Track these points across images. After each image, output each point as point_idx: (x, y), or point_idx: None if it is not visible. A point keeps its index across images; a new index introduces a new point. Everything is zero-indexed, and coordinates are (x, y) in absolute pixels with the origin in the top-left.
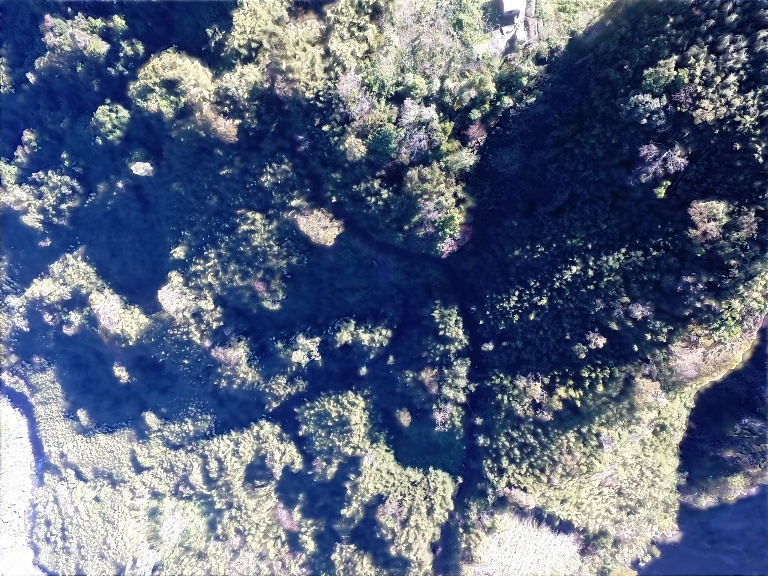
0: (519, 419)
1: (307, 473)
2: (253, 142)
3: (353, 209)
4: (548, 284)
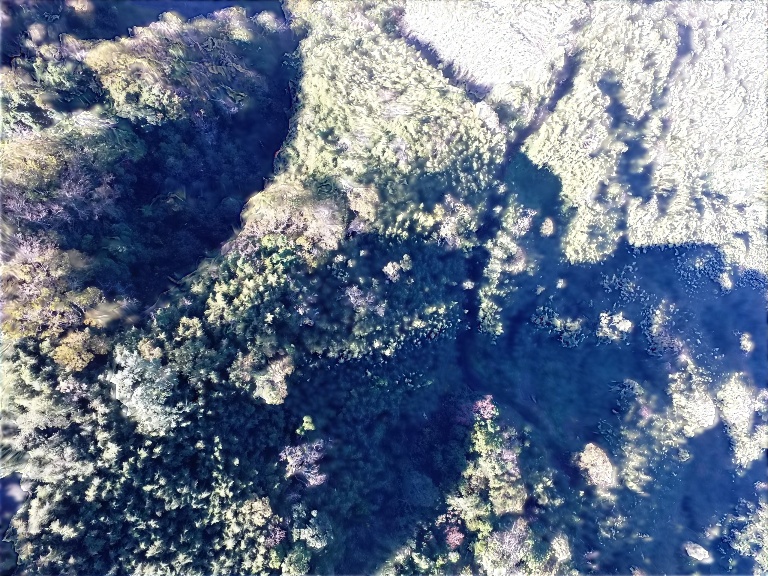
0: None
1: None
2: (614, 560)
3: (562, 475)
4: None
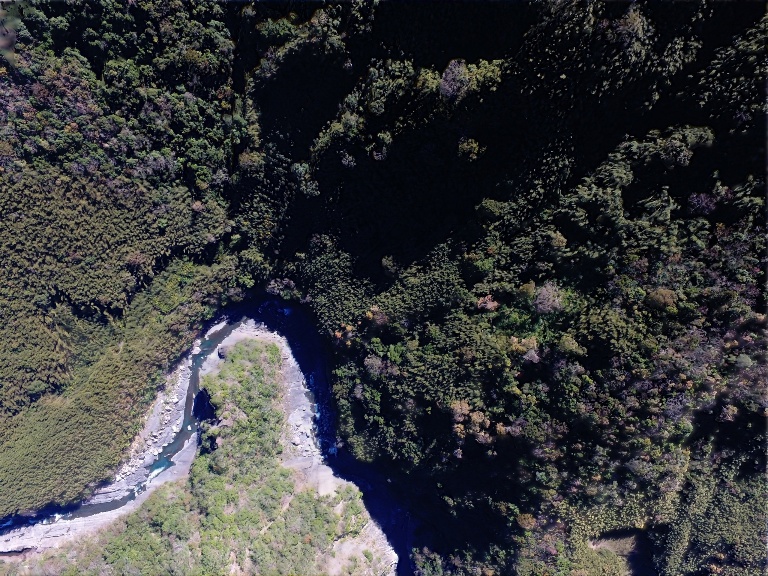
0: None
1: (719, 144)
2: None
3: None
4: None
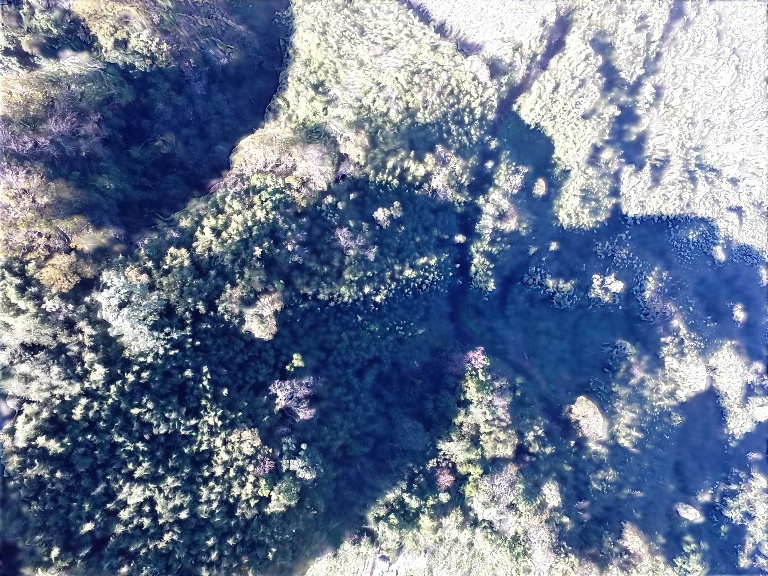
0: None
1: None
2: (606, 514)
3: (554, 426)
4: None
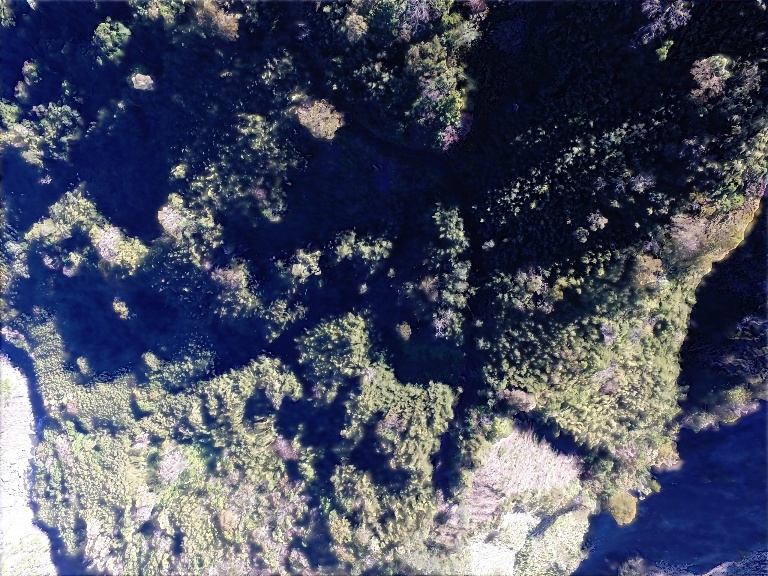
0: (520, 317)
1: (307, 402)
2: (254, 41)
3: (354, 99)
4: (549, 170)
